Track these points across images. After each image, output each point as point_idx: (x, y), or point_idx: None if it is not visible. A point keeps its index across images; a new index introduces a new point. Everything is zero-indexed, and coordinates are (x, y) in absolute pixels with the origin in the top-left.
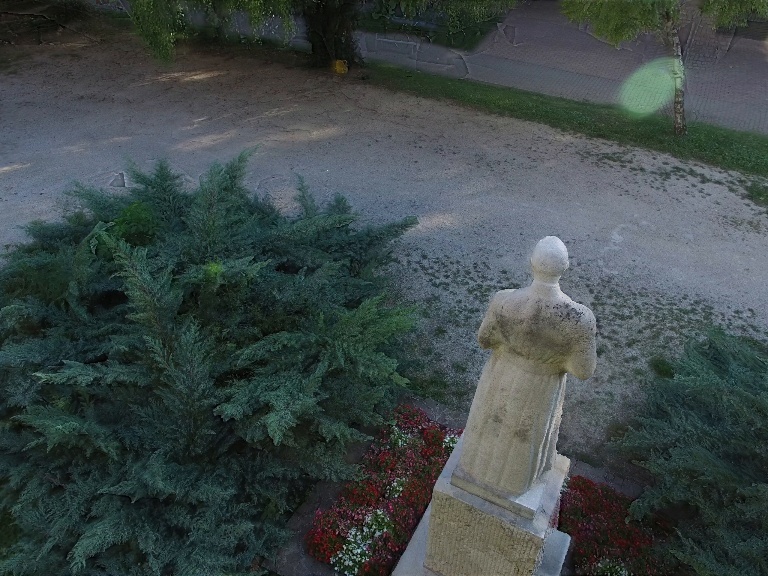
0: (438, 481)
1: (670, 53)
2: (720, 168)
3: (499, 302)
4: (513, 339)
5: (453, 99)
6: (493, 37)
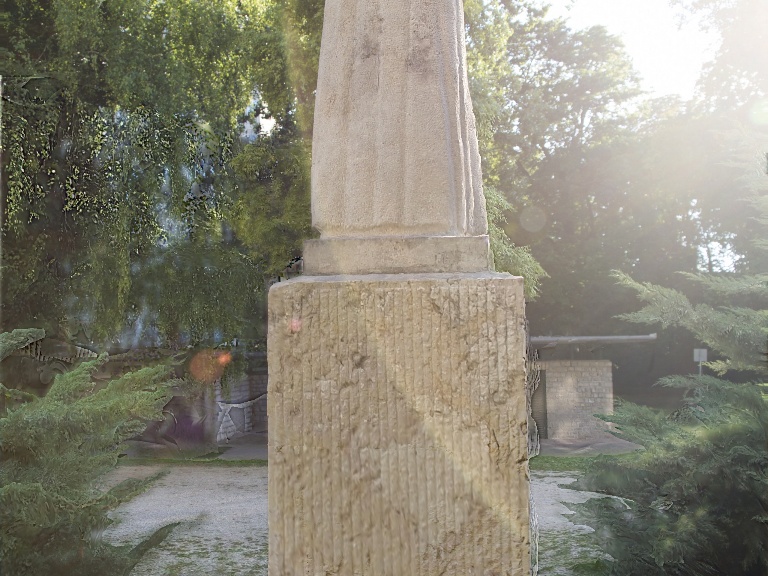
0: None
1: None
2: (552, 470)
3: None
4: None
5: (170, 463)
6: (215, 433)
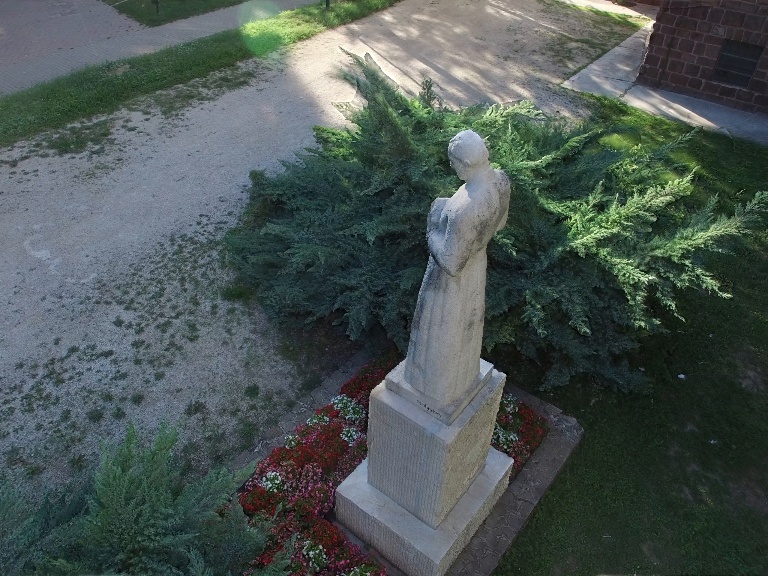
0: (444, 437)
1: None
2: (4, 147)
3: (474, 215)
4: None
5: None
6: None
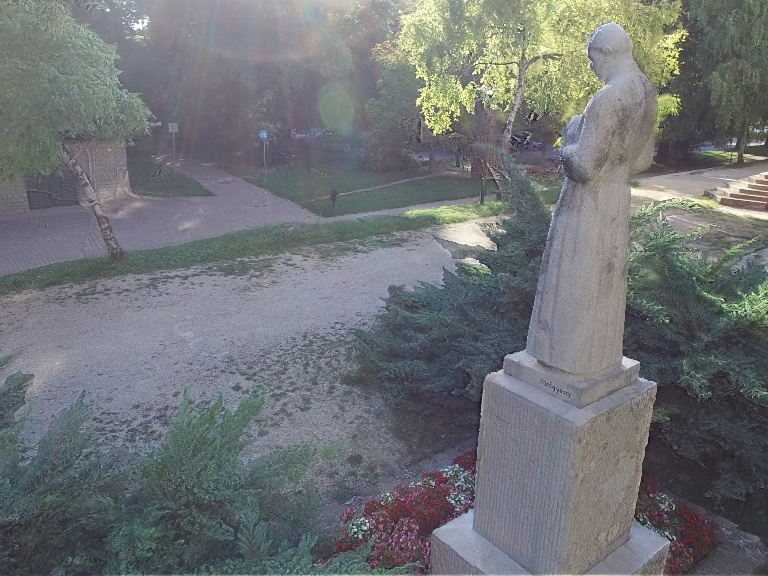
0: (572, 418)
1: (75, 185)
2: (182, 268)
3: (615, 97)
4: (630, 136)
5: None
6: None
